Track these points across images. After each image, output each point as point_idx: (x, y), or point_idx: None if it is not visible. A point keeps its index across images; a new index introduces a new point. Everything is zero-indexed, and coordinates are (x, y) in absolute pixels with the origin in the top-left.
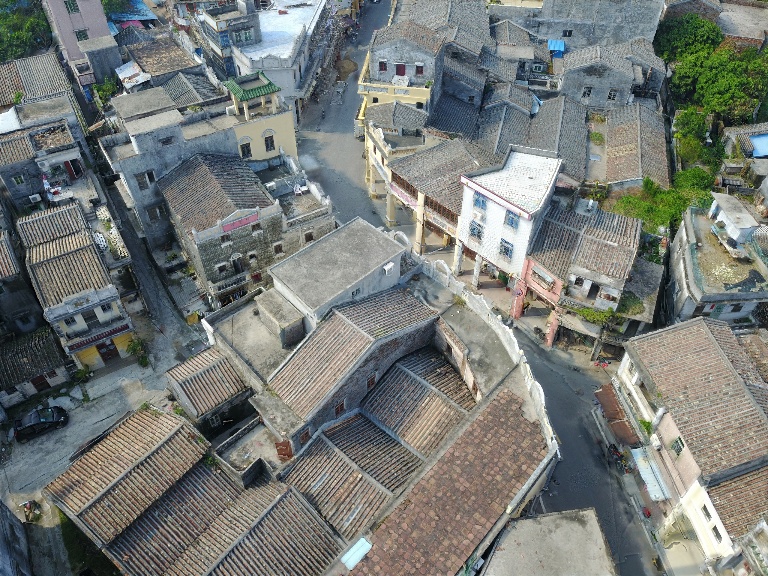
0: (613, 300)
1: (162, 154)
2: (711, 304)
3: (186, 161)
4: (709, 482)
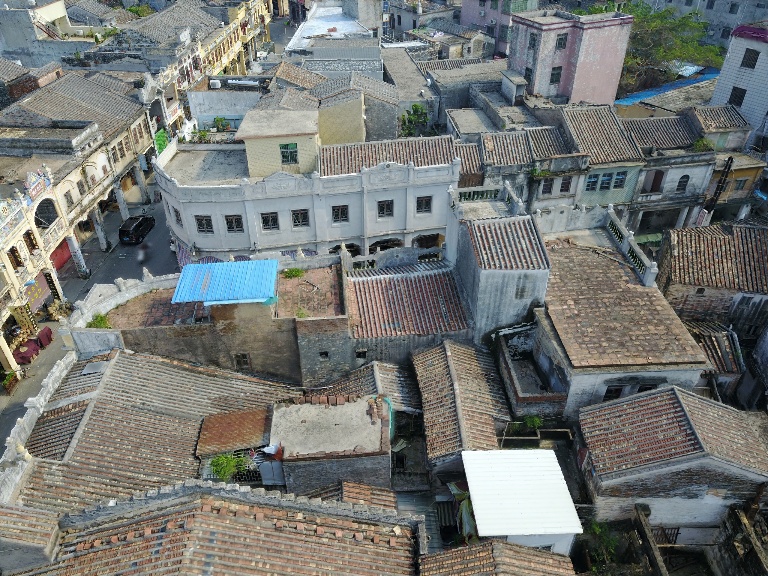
0: None
1: None
2: None
3: None
4: None
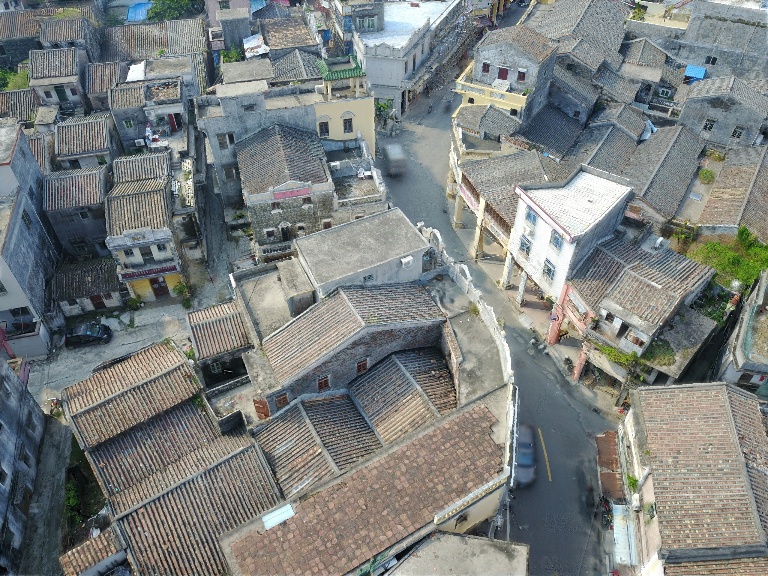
0: (642, 345)
1: (244, 119)
2: (759, 375)
3: (265, 129)
4: (667, 557)
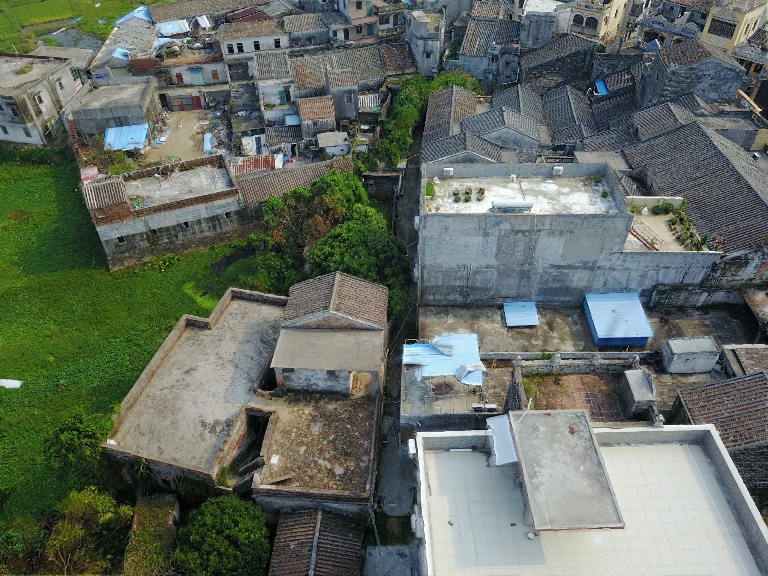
0: None
1: None
2: None
3: None
4: None
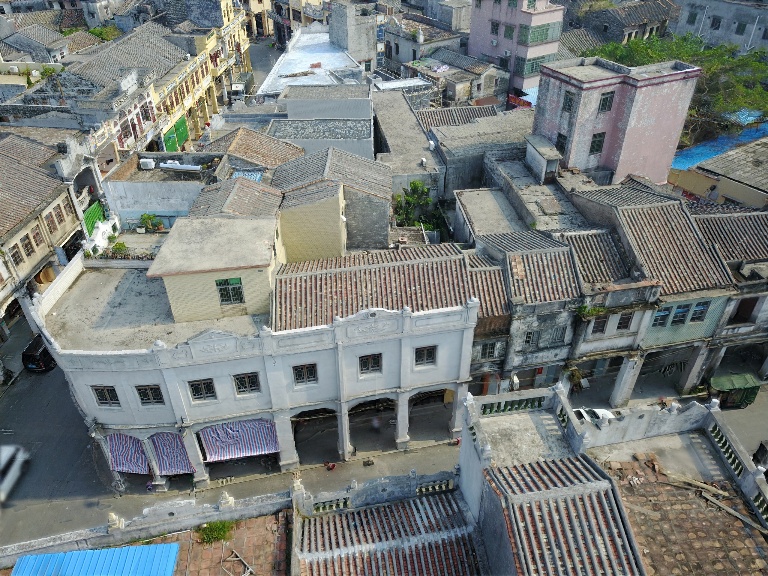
0: None
1: None
2: None
3: None
4: None
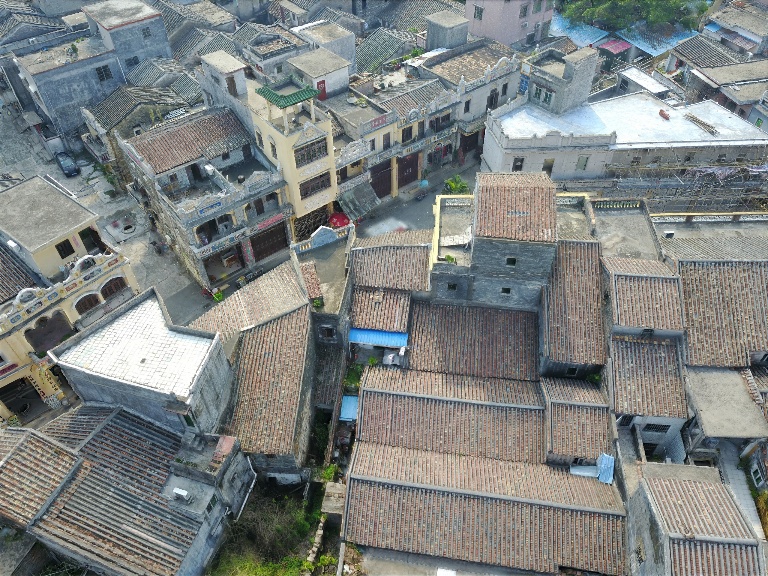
0: None
1: (215, 88)
2: None
3: (224, 107)
4: None
